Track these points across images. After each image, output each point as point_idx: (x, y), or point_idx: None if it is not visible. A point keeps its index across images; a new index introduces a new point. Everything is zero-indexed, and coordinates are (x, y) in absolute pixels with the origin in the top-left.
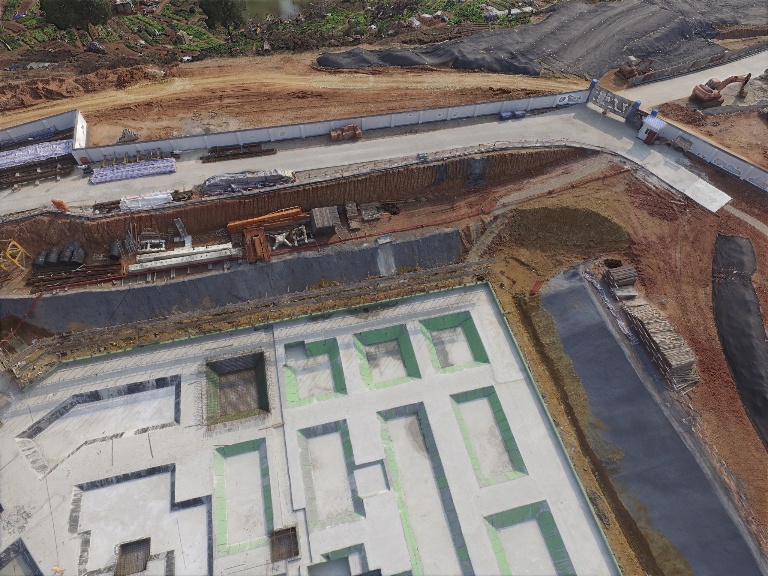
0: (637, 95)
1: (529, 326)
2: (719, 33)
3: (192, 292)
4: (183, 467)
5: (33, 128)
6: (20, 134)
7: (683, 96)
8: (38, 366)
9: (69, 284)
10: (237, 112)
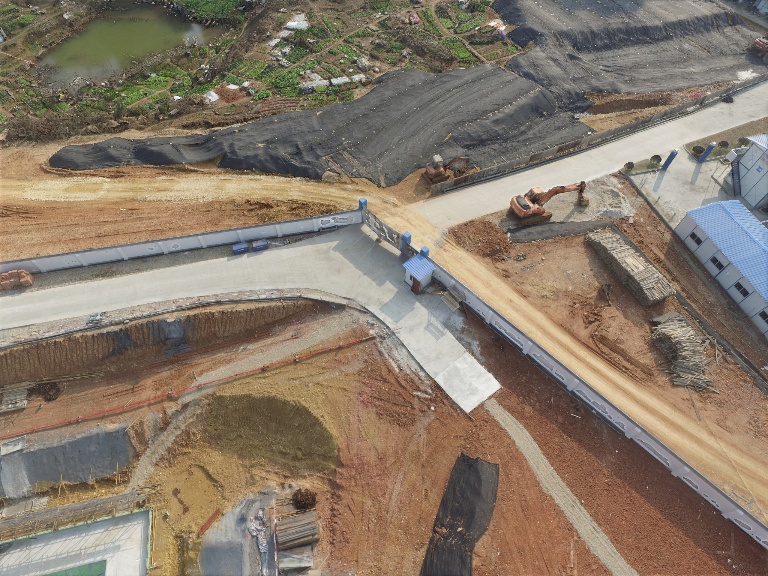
0: (438, 208)
1: None
2: (591, 105)
3: None
4: None
5: None
6: None
7: (501, 207)
8: None
9: None
10: None
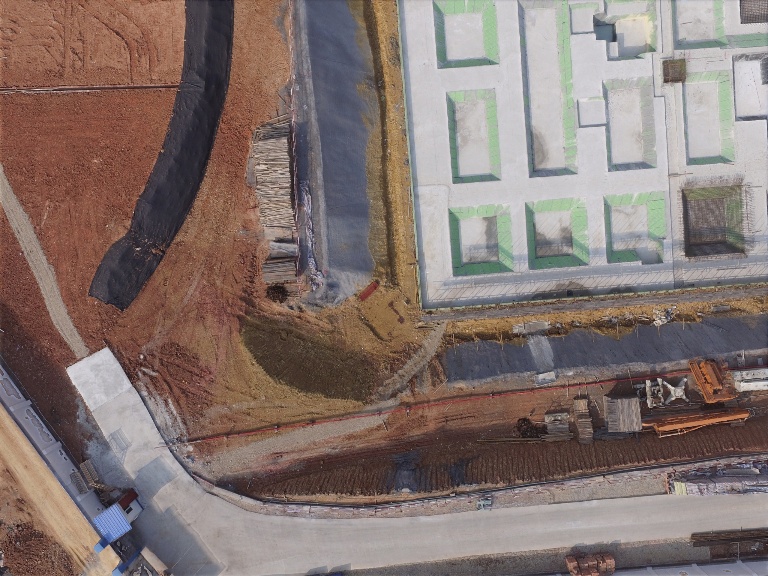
0: None
1: (390, 248)
2: None
3: None
4: (762, 149)
5: None
6: None
7: None
8: None
9: None
10: None
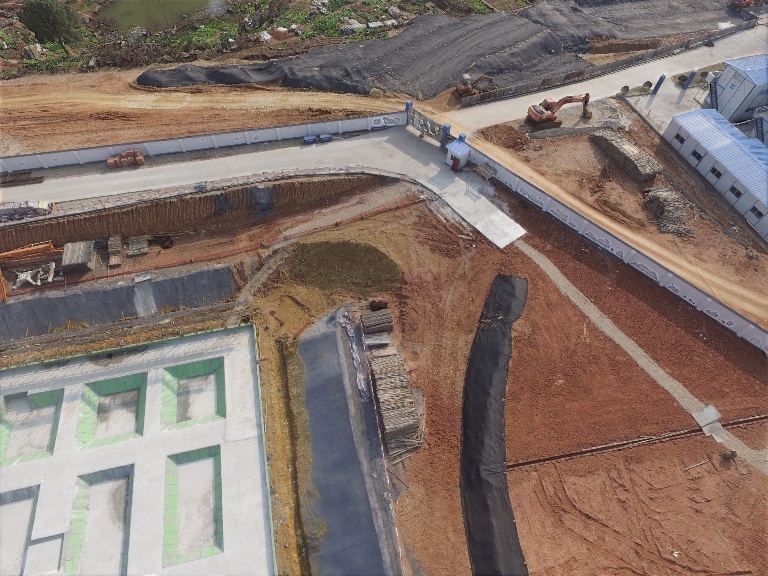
0: (468, 116)
1: (285, 374)
2: (592, 47)
3: None
4: None
5: None
6: None
7: (520, 117)
8: None
9: None
10: (24, 135)
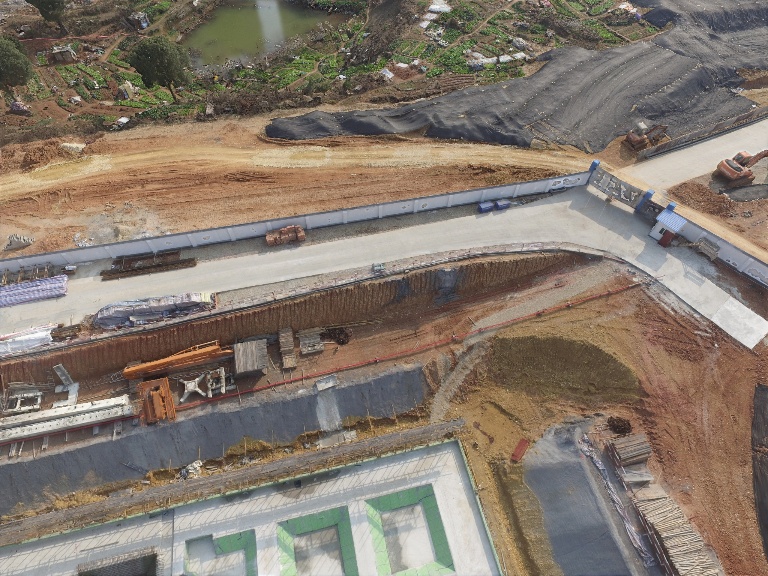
0: (649, 172)
1: (509, 507)
2: (744, 81)
3: (70, 466)
4: None
5: None
6: None
7: (705, 171)
8: None
9: None
10: (158, 204)
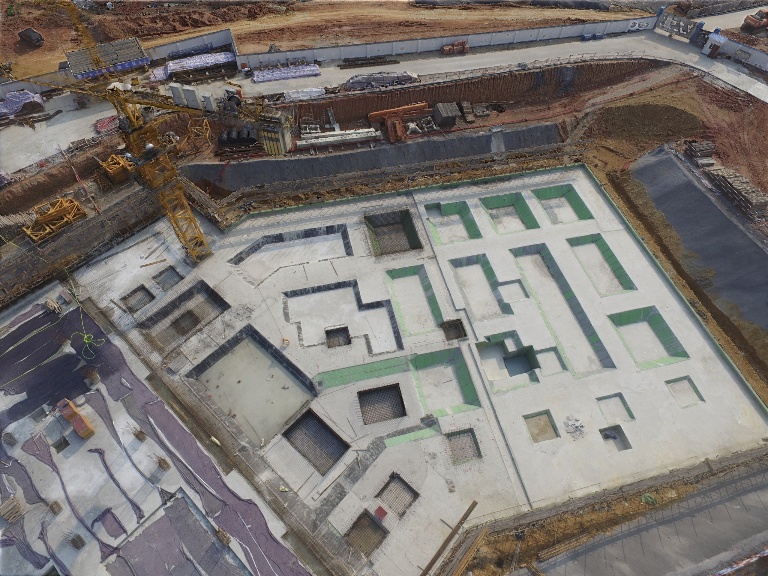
0: None
1: (622, 195)
2: None
3: (346, 165)
4: (363, 282)
5: (195, 43)
6: (185, 48)
7: (735, 26)
8: (230, 217)
9: (250, 154)
10: (357, 35)
